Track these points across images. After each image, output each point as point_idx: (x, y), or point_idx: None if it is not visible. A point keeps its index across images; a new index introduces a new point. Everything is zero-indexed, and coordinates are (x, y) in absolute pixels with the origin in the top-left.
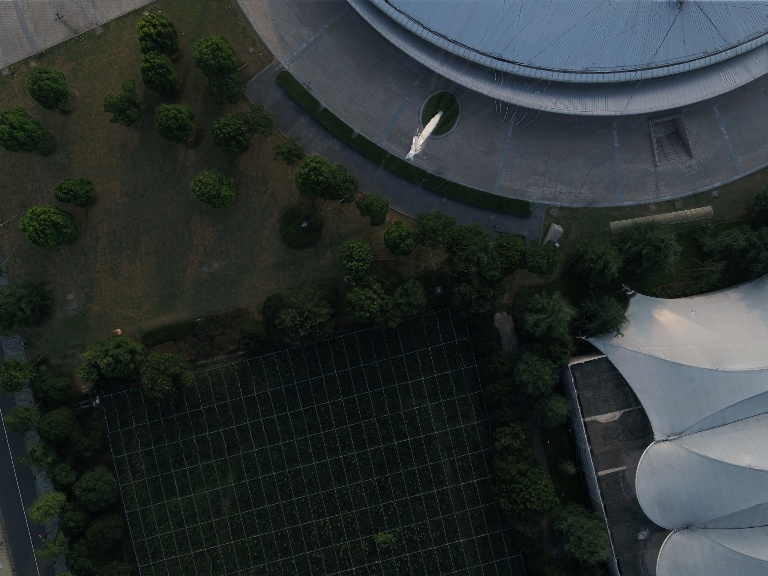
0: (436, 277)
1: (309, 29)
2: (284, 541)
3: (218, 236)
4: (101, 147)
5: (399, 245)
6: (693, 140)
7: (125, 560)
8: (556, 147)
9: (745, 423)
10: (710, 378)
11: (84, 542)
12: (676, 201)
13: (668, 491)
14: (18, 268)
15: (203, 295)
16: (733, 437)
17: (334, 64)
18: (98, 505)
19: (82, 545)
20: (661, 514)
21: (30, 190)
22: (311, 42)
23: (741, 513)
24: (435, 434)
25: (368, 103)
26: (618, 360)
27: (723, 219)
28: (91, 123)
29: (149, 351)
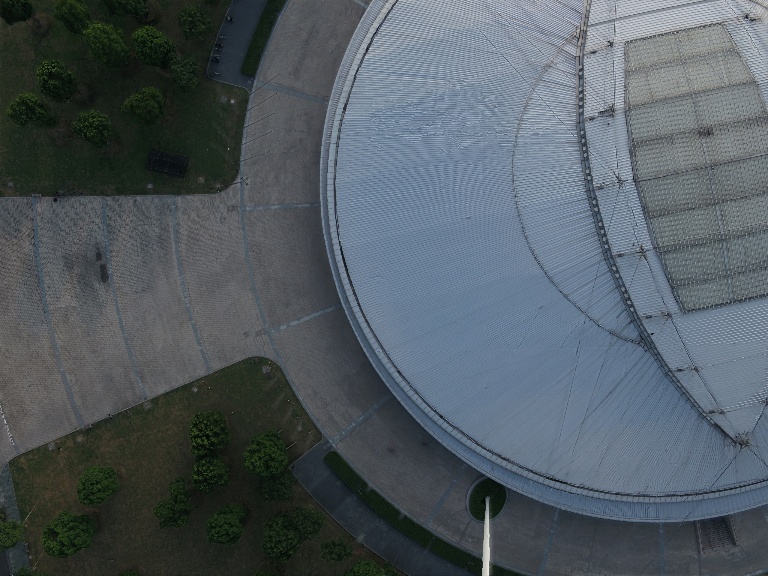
0: None
1: (358, 409)
2: None
3: None
4: (147, 527)
5: None
6: (737, 528)
7: None
8: (601, 533)
9: None
10: None
11: None
12: None
13: None
14: None
15: None
16: None
17: (382, 444)
18: None
19: None
20: None
21: (74, 569)
22: (360, 422)
23: None
24: None
25: (415, 484)
26: None
27: None
28: (137, 502)
29: None
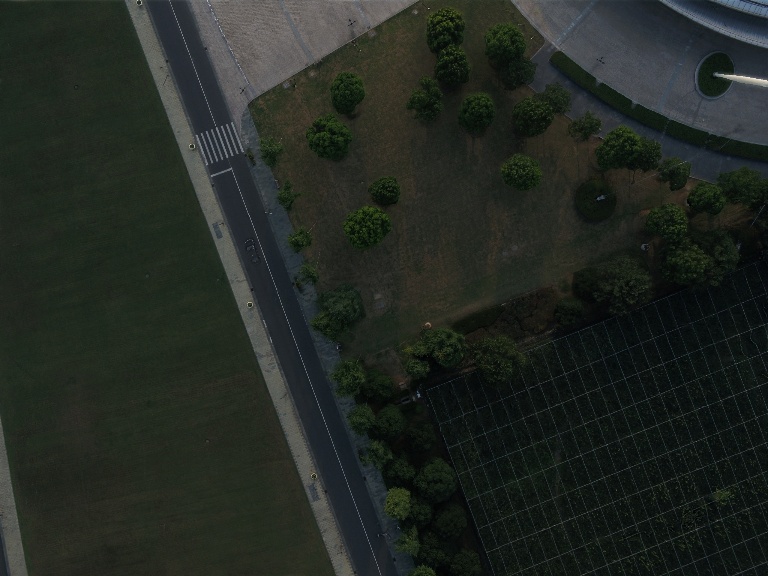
0: (733, 234)
1: (576, 8)
2: (624, 510)
3: (514, 220)
4: (391, 146)
5: (713, 204)
6: None
7: (468, 548)
8: None
9: None
10: None
11: (432, 534)
12: None
13: None
14: (323, 274)
15: (506, 279)
16: None
17: (604, 39)
18: (444, 496)
19: (431, 537)
20: None
21: (326, 197)
22: (579, 21)
23: None
24: (758, 387)
25: (642, 73)
26: None
27: None
28: (378, 124)
29: (465, 340)
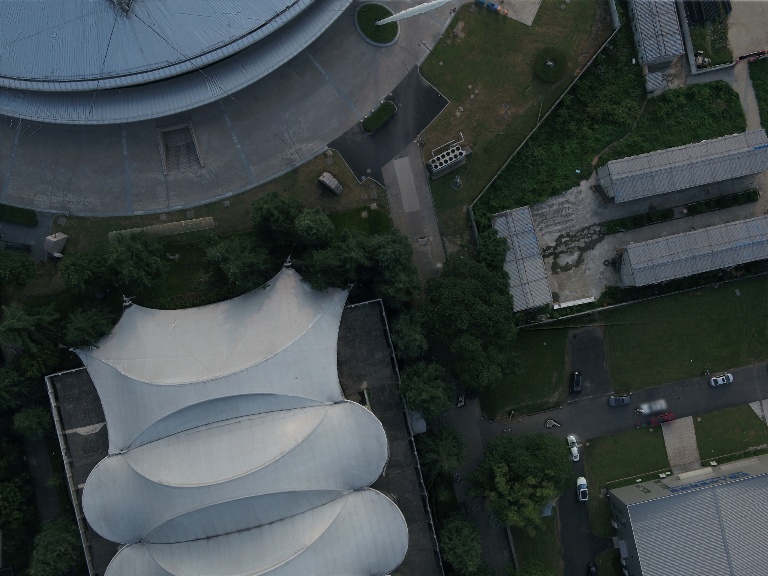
0: None
1: None
2: None
3: None
4: None
5: None
6: (204, 149)
7: None
8: (64, 155)
9: (176, 438)
10: (146, 392)
11: None
12: (187, 211)
13: (111, 505)
14: None
15: None
16: (162, 452)
17: None
18: None
19: None
20: (108, 528)
21: None
22: None
23: (162, 528)
24: None
25: None
26: (94, 372)
27: (236, 229)
28: None
29: None
